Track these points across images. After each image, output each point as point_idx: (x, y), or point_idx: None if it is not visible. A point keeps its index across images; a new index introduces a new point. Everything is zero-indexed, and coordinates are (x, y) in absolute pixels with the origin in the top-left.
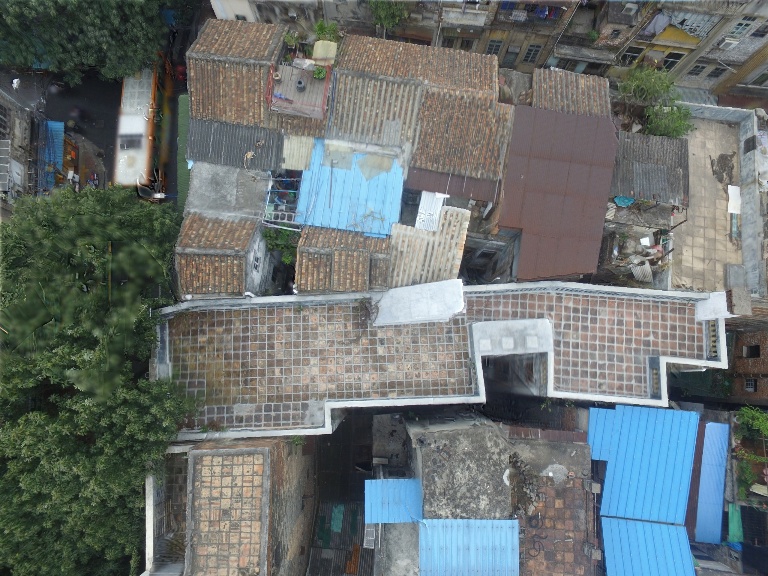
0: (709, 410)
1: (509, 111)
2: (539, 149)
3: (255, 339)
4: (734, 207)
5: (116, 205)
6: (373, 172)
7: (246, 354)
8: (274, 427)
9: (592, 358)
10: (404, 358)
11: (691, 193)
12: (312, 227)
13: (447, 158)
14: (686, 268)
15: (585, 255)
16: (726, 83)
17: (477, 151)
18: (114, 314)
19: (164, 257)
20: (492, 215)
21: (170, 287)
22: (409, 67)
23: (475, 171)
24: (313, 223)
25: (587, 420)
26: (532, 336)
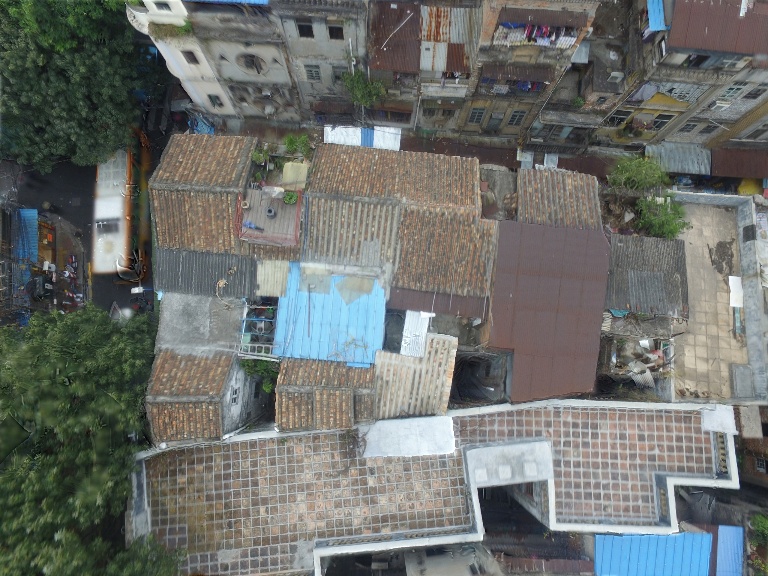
0: (721, 504)
1: (493, 226)
2: (527, 265)
3: (237, 476)
4: (736, 300)
5: (82, 347)
6: (353, 295)
7: (229, 493)
8: (262, 574)
9: (595, 477)
10: (396, 488)
11: (690, 287)
12: (291, 359)
13: (430, 276)
14: (689, 370)
15: (582, 373)
16: (719, 139)
17: (462, 268)
18: (99, 404)
19: (135, 402)
20: (482, 328)
21: (143, 433)
22: (385, 182)
23: (461, 289)
24: (292, 355)
25: (593, 545)
26: (530, 463)
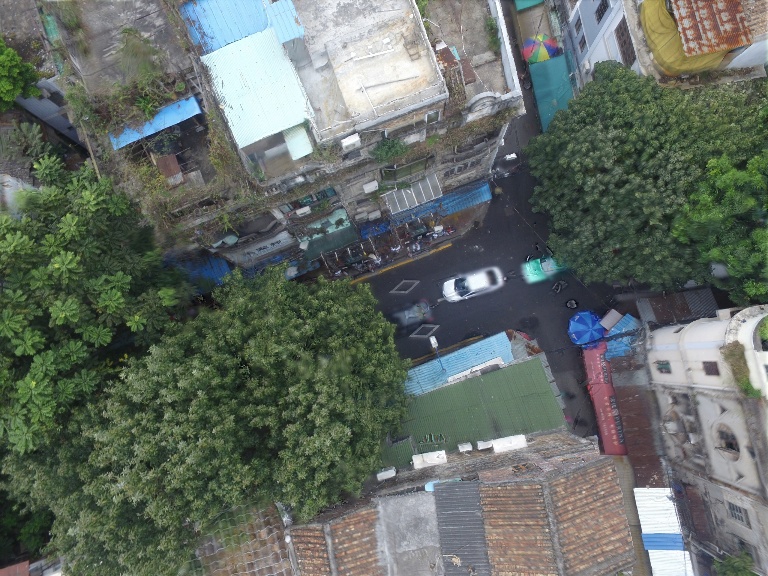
0: None
1: None
2: None
3: None
4: None
5: (363, 430)
6: None
7: None
8: None
9: None
10: None
11: None
12: None
13: None
14: None
15: None
16: None
17: None
18: None
19: (323, 497)
20: None
21: None
22: None
23: None
24: None
25: None
26: None
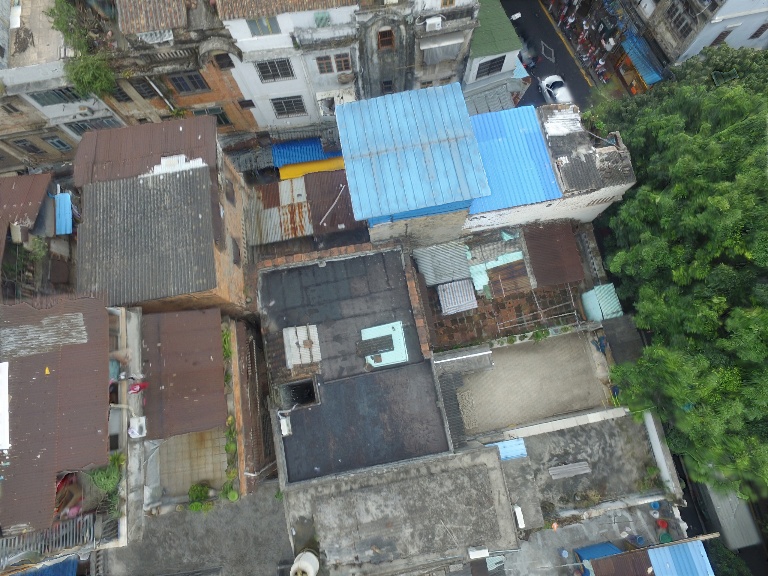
0: None
1: None
2: None
3: None
4: (16, 11)
5: None
6: None
7: None
8: None
9: None
10: None
11: None
12: None
13: None
14: None
15: None
16: None
17: None
18: None
19: None
20: None
21: None
22: None
23: None
24: None
25: None
26: None
